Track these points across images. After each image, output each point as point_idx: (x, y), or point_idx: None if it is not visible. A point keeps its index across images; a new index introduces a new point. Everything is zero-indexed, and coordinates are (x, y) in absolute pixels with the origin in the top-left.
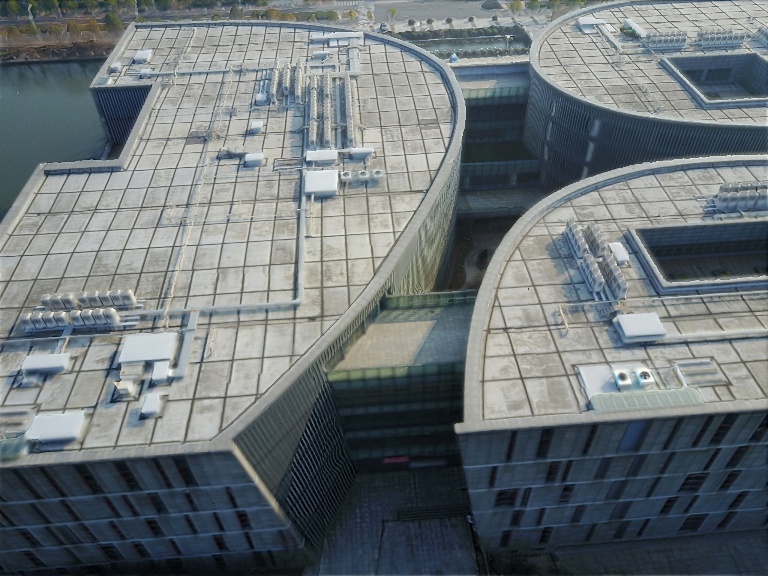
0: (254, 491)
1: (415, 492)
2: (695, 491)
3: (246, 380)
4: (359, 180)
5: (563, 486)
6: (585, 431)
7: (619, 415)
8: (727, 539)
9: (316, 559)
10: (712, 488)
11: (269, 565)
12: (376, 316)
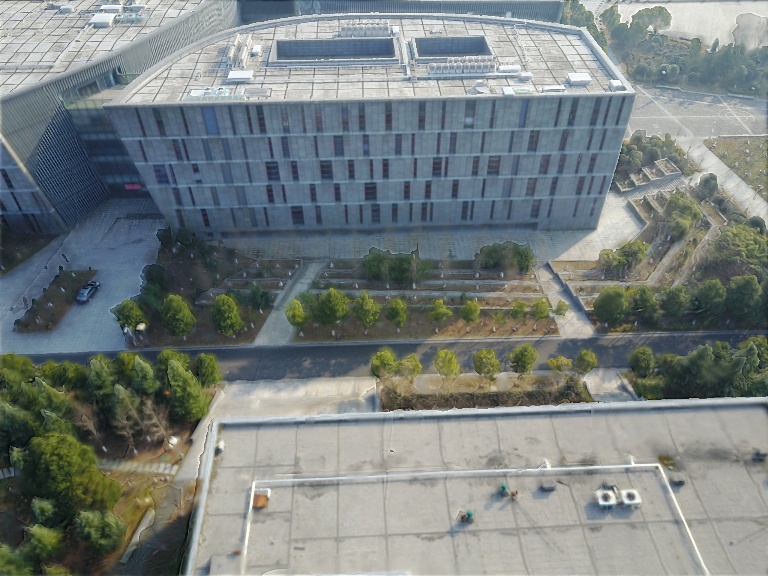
0: (4, 150)
1: (143, 207)
2: (279, 180)
3: (4, 91)
4: (128, 20)
5: (191, 165)
6: (178, 112)
7: (193, 102)
8: (331, 237)
9: (67, 230)
10: (288, 178)
11: (37, 231)
12: (111, 86)
